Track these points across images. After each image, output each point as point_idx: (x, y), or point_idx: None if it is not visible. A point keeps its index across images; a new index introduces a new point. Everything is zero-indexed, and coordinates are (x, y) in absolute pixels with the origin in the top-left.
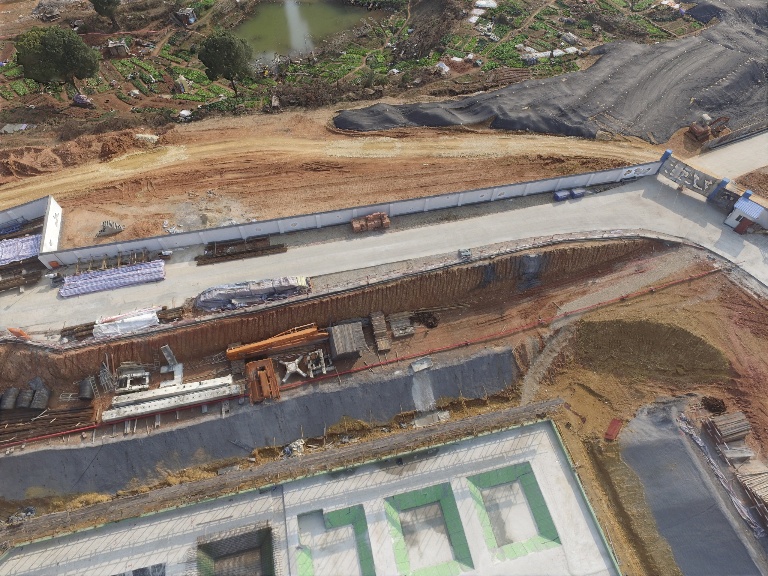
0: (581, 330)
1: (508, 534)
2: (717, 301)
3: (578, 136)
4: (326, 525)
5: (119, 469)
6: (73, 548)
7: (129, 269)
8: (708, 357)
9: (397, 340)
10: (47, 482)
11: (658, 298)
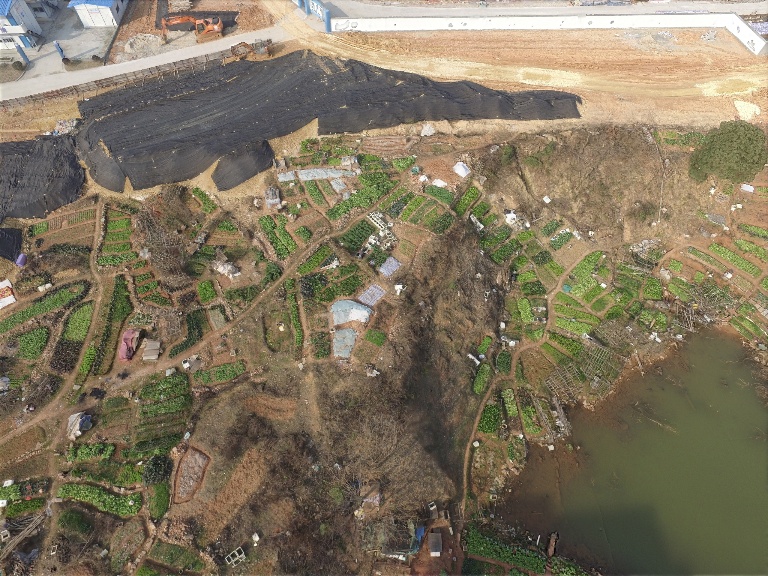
0: None
1: None
2: None
3: None
4: None
5: None
6: None
7: None
8: None
9: None
10: None
11: None
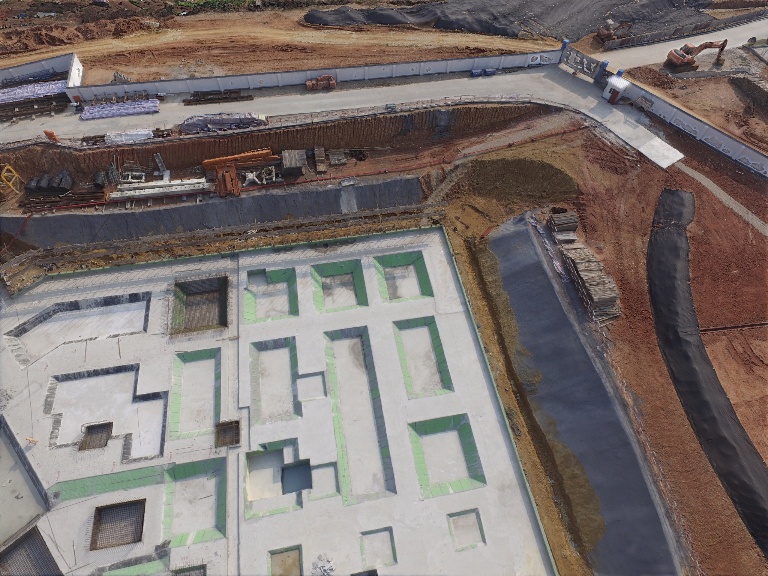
0: (475, 167)
1: (399, 293)
2: (580, 147)
3: (504, 35)
4: (268, 280)
5: (121, 233)
6: (88, 280)
7: (133, 104)
8: (564, 183)
9: (333, 167)
10: (70, 239)
11: (536, 145)
